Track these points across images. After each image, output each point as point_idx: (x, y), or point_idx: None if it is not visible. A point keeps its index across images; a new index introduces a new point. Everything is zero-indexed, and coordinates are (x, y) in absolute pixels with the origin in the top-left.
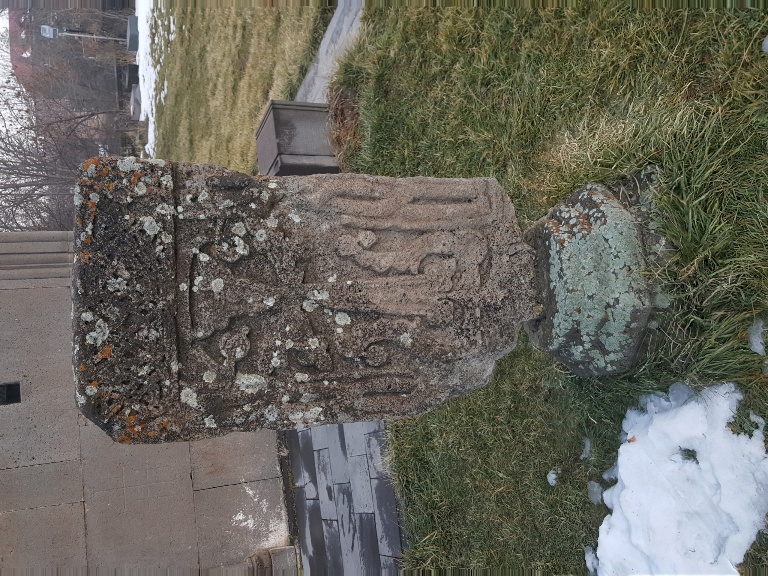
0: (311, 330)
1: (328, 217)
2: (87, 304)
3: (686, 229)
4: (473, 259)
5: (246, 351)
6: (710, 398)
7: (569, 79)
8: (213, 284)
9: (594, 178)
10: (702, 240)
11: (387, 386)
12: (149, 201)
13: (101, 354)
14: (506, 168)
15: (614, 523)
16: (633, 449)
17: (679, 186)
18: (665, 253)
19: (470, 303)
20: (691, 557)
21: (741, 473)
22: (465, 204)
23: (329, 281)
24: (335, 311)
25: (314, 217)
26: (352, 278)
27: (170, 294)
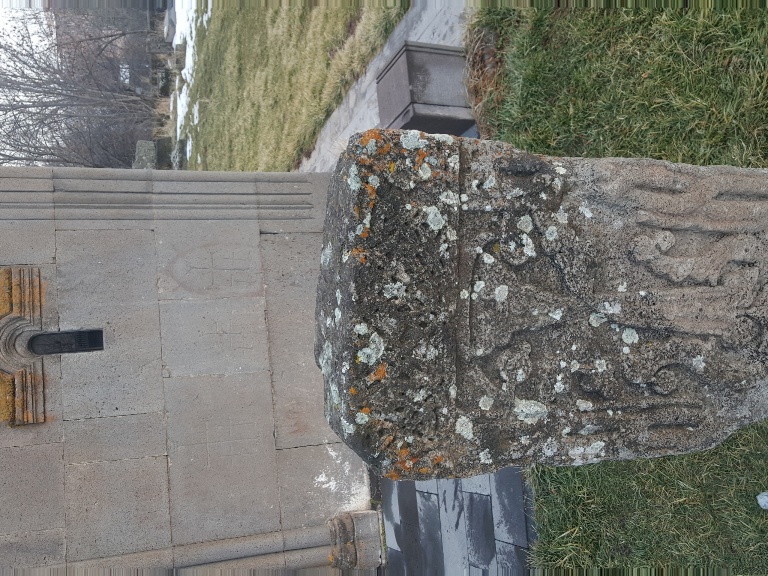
0: (599, 350)
1: (621, 212)
2: (361, 314)
3: None
4: None
5: (528, 373)
6: None
7: None
8: (497, 292)
9: None
10: None
11: (675, 418)
12: (432, 187)
13: (374, 375)
14: (726, 143)
15: None
16: None
17: None
18: None
19: None
20: None
21: None
22: None
23: (619, 291)
24: (622, 327)
25: (606, 212)
26: (643, 287)
27: (452, 304)
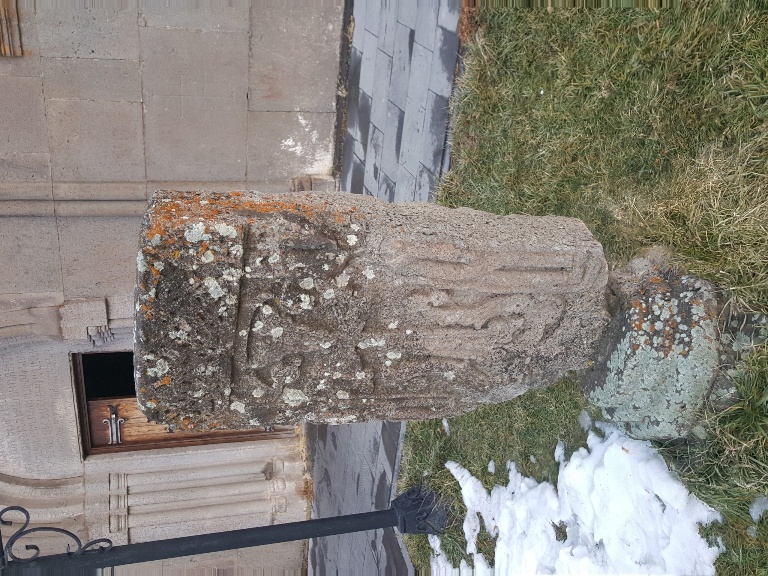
0: (360, 367)
1: (404, 273)
2: (149, 349)
3: (761, 395)
4: (542, 321)
5: (295, 379)
6: (697, 500)
7: (767, 66)
8: (273, 331)
9: (708, 277)
10: (767, 417)
11: (420, 405)
12: (216, 265)
13: (161, 383)
14: (652, 69)
15: (585, 467)
16: (623, 455)
17: None
18: (728, 400)
19: (523, 354)
20: (624, 548)
21: (688, 554)
22: (556, 274)
23: (389, 328)
24: None
25: (389, 274)
26: (413, 325)
27: (229, 343)
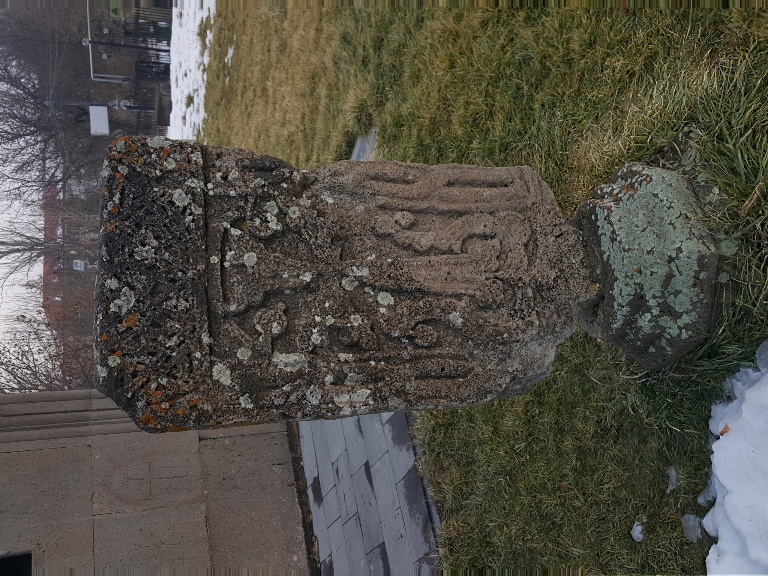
0: (352, 307)
1: (362, 200)
2: (112, 271)
3: (738, 173)
4: (517, 239)
5: (283, 327)
6: None
7: (586, 108)
8: (246, 258)
9: (630, 157)
10: (758, 177)
11: (440, 368)
12: (178, 176)
13: (126, 322)
14: None
15: (723, 547)
16: (728, 442)
17: (721, 133)
18: (721, 201)
19: (520, 282)
20: None
21: None
22: (502, 188)
23: None
24: (376, 291)
25: (348, 199)
26: (392, 258)
27: (200, 264)
